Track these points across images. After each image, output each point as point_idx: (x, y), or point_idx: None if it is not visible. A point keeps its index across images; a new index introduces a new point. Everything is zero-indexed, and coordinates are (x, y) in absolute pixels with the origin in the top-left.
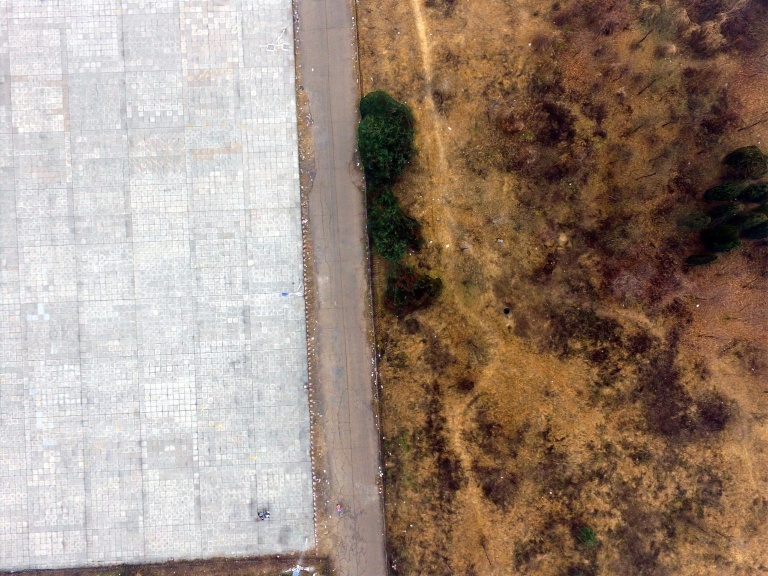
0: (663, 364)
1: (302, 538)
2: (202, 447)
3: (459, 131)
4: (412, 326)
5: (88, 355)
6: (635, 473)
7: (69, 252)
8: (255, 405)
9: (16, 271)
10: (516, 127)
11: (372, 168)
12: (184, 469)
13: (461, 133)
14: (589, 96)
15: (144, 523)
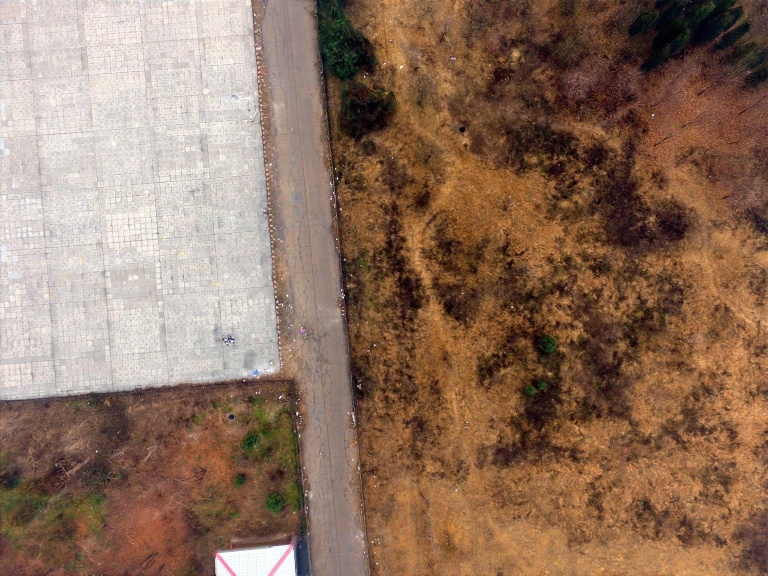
0: (620, 175)
1: (267, 362)
2: (165, 275)
3: None
4: (369, 148)
5: (49, 188)
6: (596, 284)
7: (26, 87)
8: (216, 232)
9: None
10: None
11: None
12: (148, 298)
13: None
14: None
15: (111, 352)
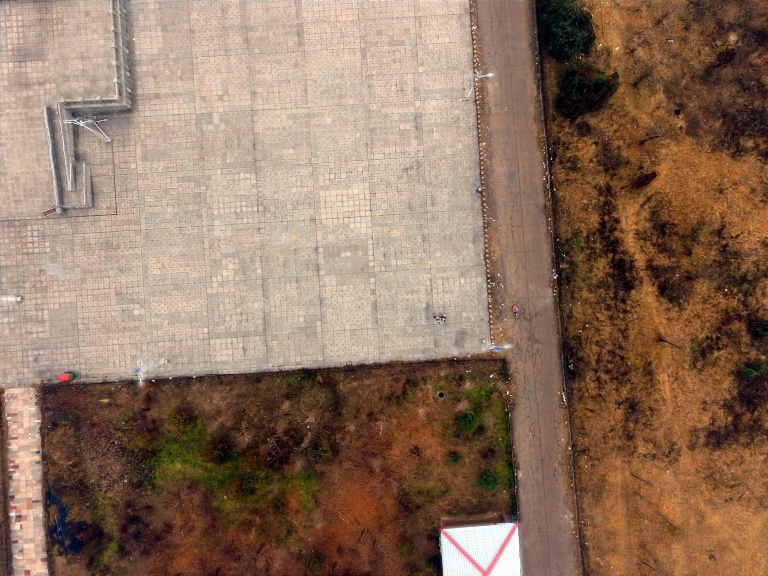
0: None
1: (478, 340)
2: (377, 252)
3: None
4: (584, 129)
5: (263, 163)
6: None
7: (243, 62)
8: (429, 210)
9: (191, 81)
10: None
11: None
12: (360, 274)
13: None
14: None
15: (322, 328)
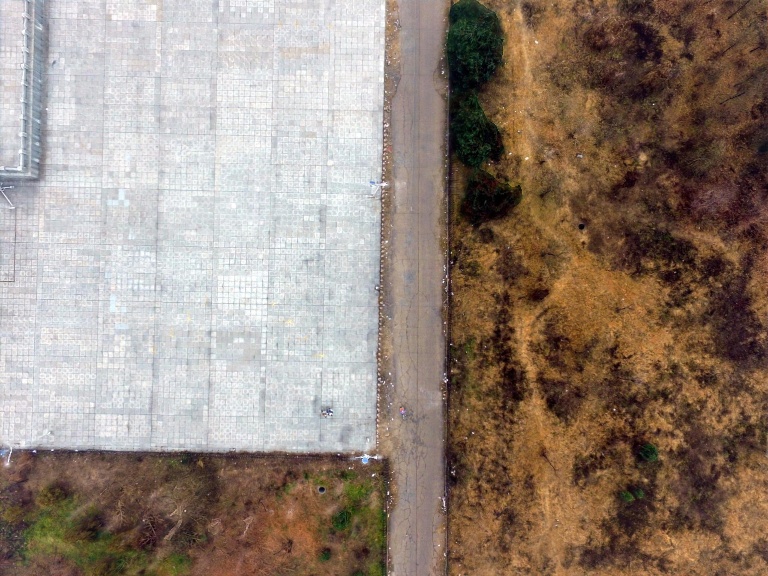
0: (735, 289)
1: (363, 438)
2: (271, 341)
3: (546, 45)
4: (486, 235)
5: (165, 243)
6: (700, 395)
7: (153, 140)
8: (325, 303)
9: (100, 155)
10: (606, 40)
11: (461, 72)
12: (251, 362)
13: (547, 47)
14: (678, 18)
15: (209, 412)
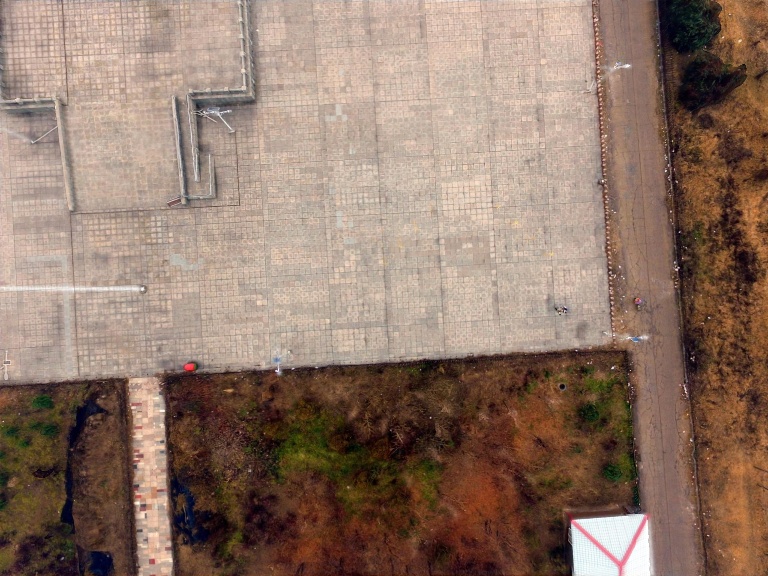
0: None
1: (599, 332)
2: (499, 244)
3: None
4: (706, 121)
5: (385, 155)
6: None
7: (365, 53)
8: (550, 202)
9: (314, 73)
10: None
11: None
12: (482, 266)
13: None
14: None
15: (444, 319)
